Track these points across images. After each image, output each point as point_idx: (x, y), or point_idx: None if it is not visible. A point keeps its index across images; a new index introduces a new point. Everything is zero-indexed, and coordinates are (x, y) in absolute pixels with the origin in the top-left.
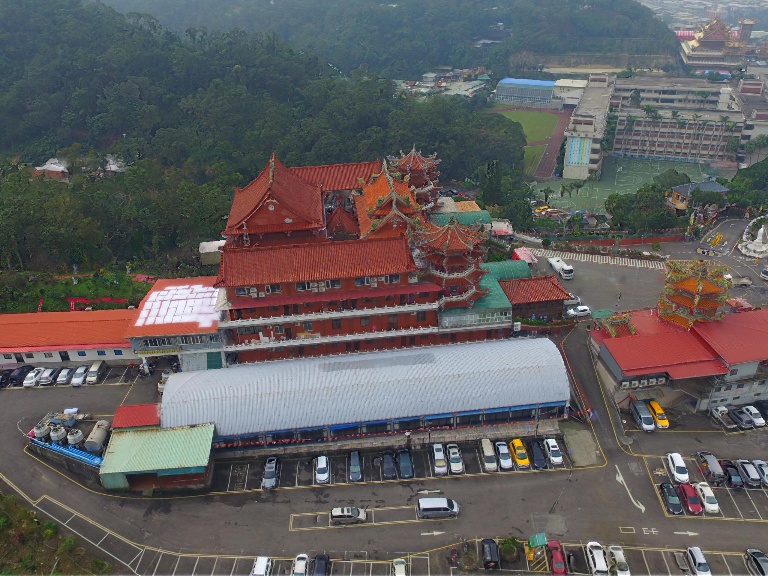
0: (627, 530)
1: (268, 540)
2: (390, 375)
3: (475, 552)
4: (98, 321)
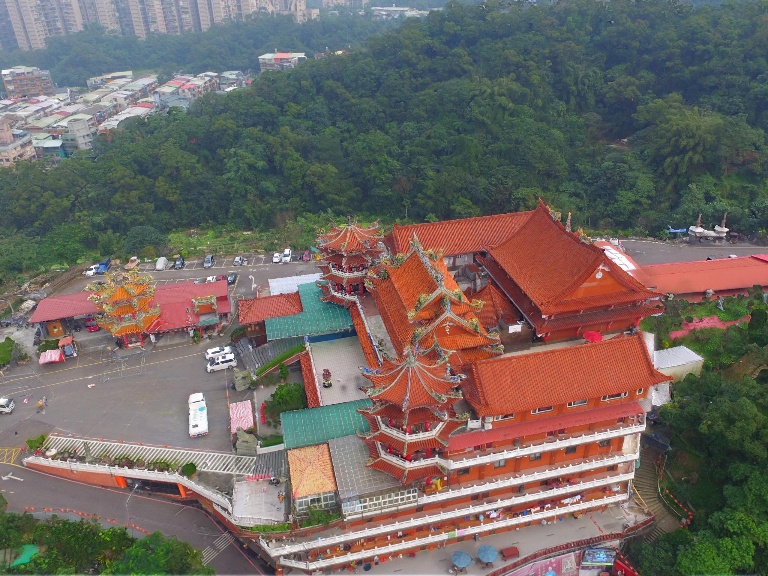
0: None
1: None
2: None
3: None
4: (672, 273)
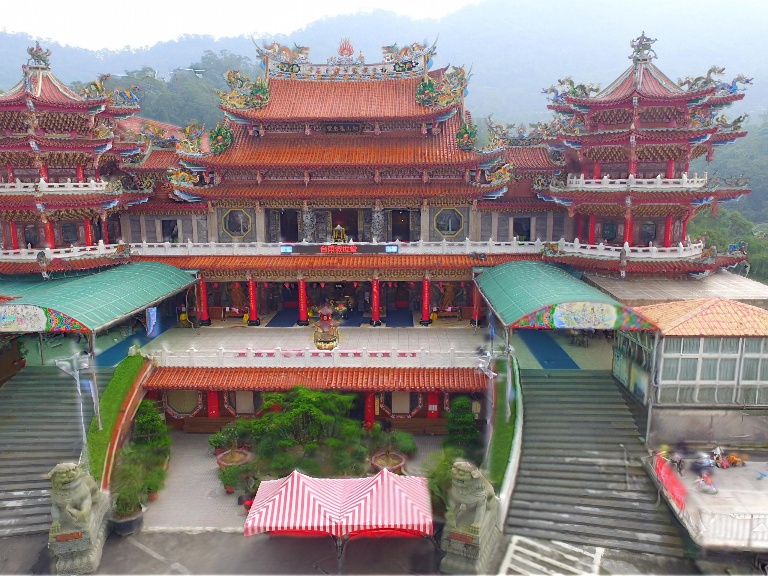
0: None
1: None
2: None
3: None
4: None
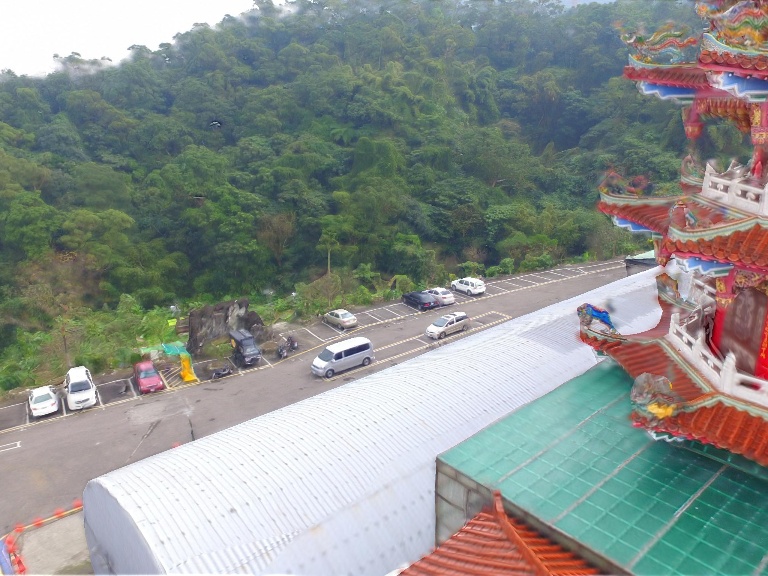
0: (6, 446)
1: (503, 303)
2: (572, 302)
3: (268, 357)
4: None
